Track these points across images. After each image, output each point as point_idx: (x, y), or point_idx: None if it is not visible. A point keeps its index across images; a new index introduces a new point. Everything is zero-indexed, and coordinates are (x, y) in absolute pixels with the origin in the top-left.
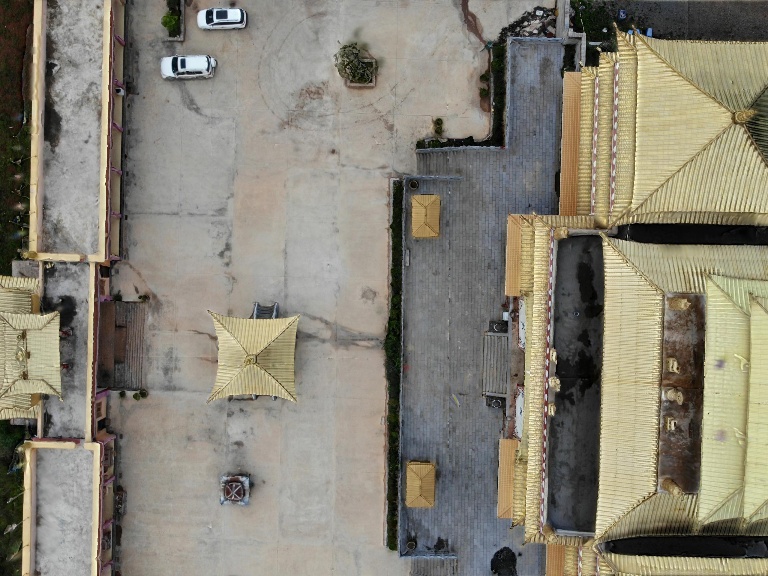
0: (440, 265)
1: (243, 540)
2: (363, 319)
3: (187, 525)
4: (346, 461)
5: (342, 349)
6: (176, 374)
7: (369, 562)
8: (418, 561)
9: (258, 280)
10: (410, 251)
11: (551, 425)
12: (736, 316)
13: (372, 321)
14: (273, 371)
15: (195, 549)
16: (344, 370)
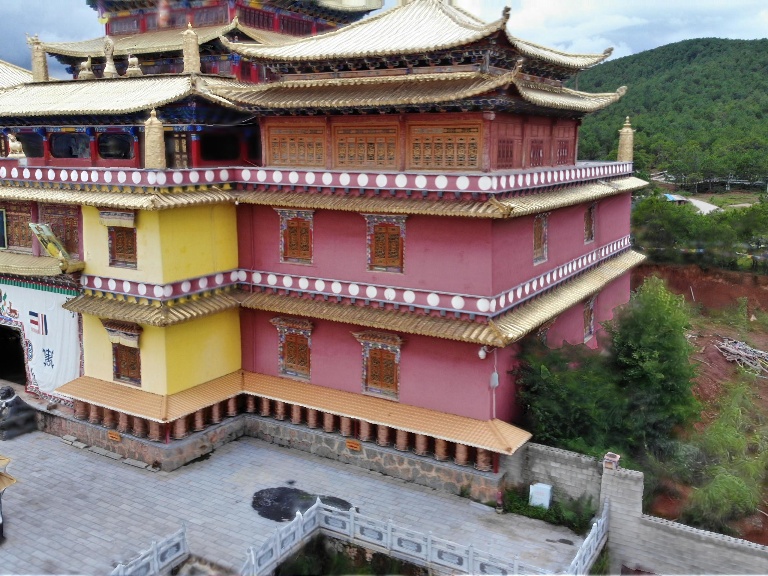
0: None
1: None
2: None
3: None
4: None
5: None
6: None
7: None
8: None
9: None
10: None
11: None
12: None
13: None
14: None
15: None
16: None
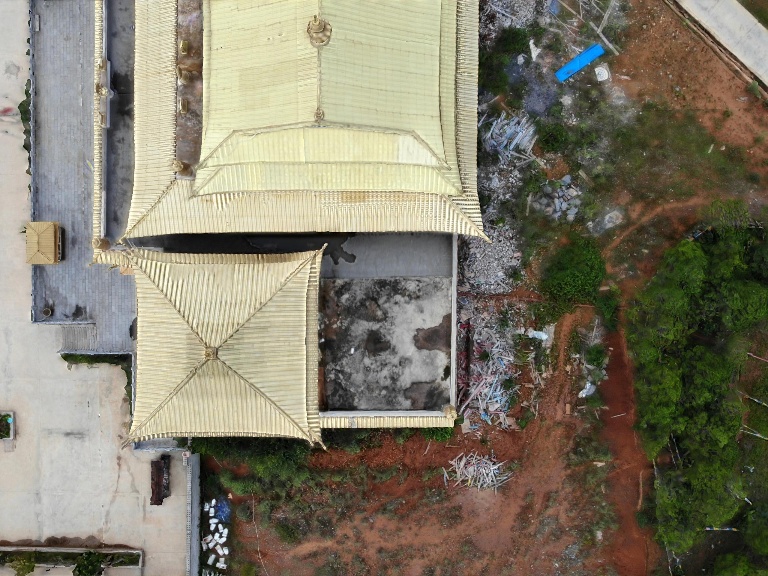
0: (71, 30)
1: None
2: (7, 94)
3: None
4: None
5: None
6: None
7: (20, 339)
8: (68, 337)
9: None
10: (40, 16)
11: (111, 141)
12: None
13: (16, 96)
14: None
15: None
16: None
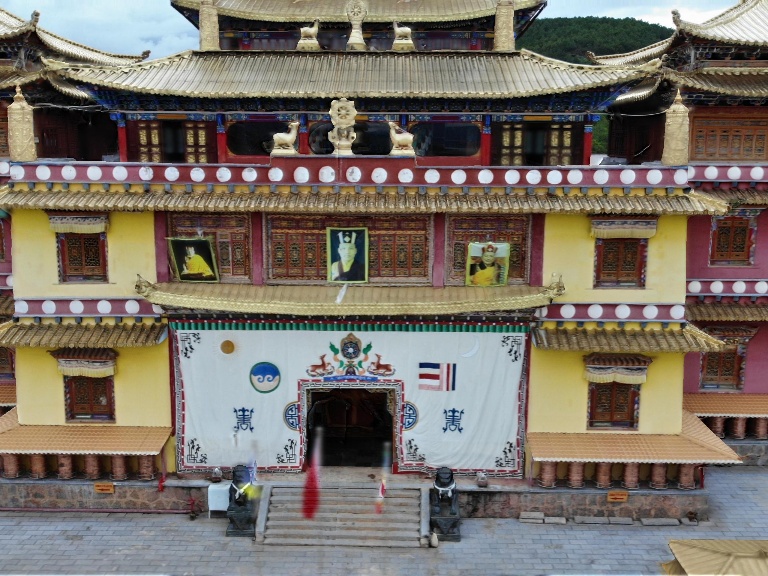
0: None
1: None
2: None
3: None
4: None
5: None
6: None
7: None
8: None
9: None
10: None
11: None
12: (238, 1)
13: None
14: None
15: None
16: None
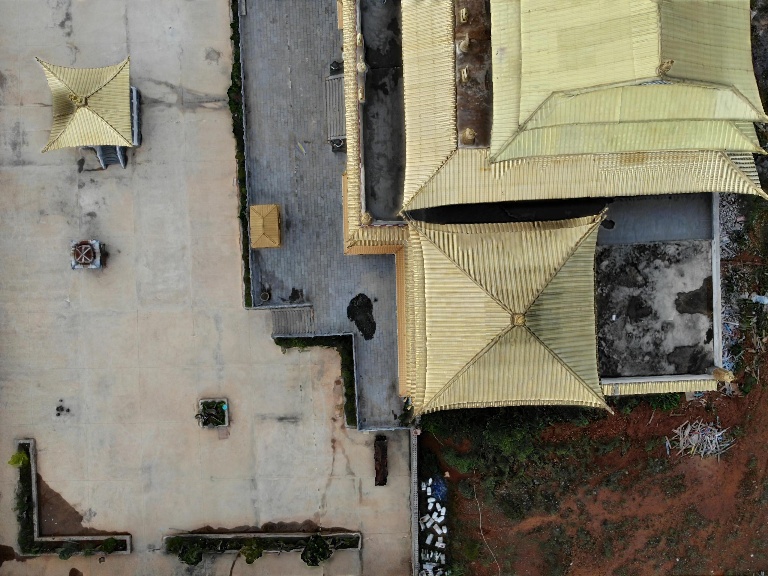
0: (277, 13)
1: (102, 312)
2: (208, 81)
3: (45, 300)
4: (200, 225)
5: (189, 112)
6: (24, 148)
7: (230, 326)
8: (279, 321)
9: (100, 48)
10: (246, 0)
11: (366, 116)
12: None
13: (218, 82)
14: (106, 116)
15: (54, 324)
16: (193, 133)
